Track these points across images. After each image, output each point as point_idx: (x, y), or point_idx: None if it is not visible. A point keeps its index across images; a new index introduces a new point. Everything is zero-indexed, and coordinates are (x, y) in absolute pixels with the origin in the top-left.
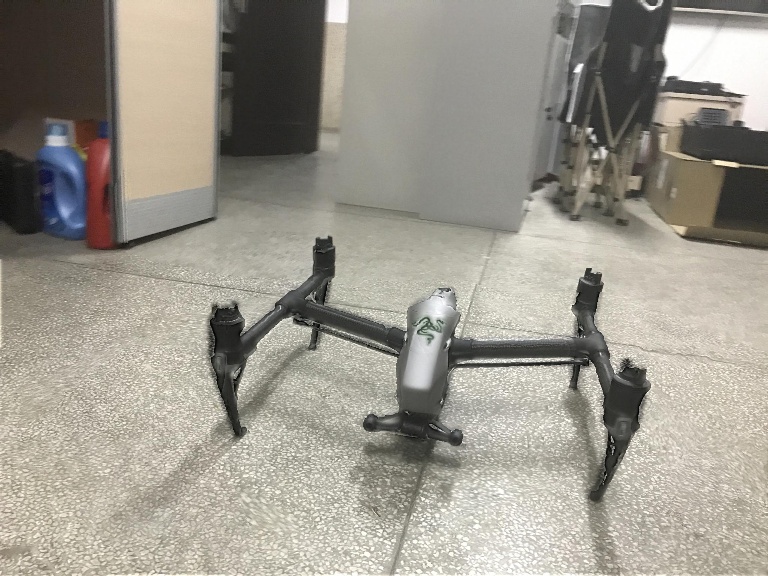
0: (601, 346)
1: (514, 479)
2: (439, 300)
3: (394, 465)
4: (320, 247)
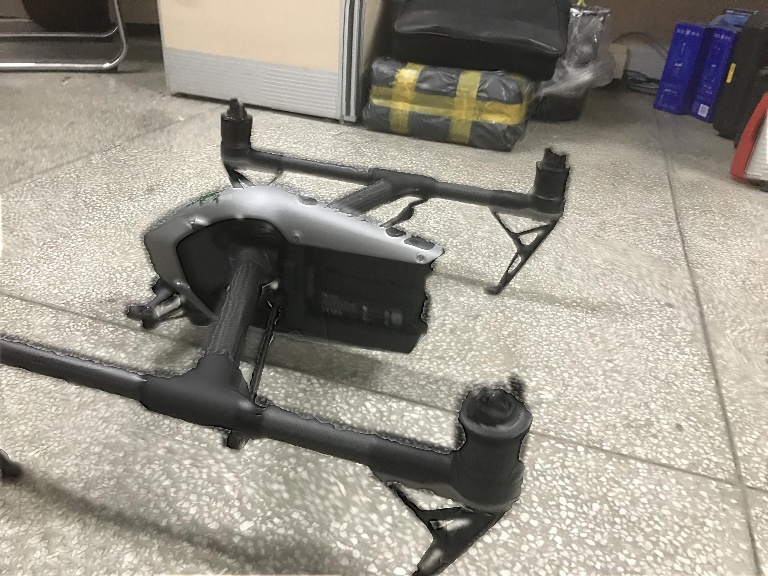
0: (171, 385)
1: (105, 402)
2: (291, 200)
3: (182, 320)
4: (544, 161)
